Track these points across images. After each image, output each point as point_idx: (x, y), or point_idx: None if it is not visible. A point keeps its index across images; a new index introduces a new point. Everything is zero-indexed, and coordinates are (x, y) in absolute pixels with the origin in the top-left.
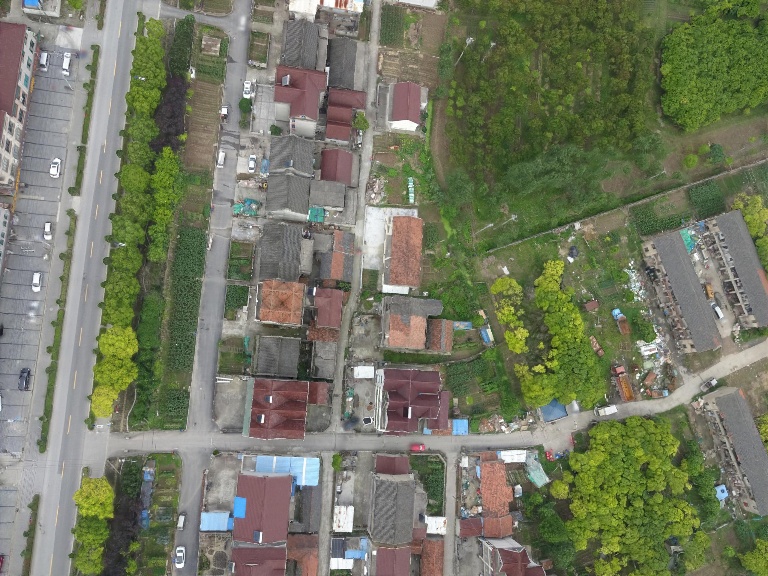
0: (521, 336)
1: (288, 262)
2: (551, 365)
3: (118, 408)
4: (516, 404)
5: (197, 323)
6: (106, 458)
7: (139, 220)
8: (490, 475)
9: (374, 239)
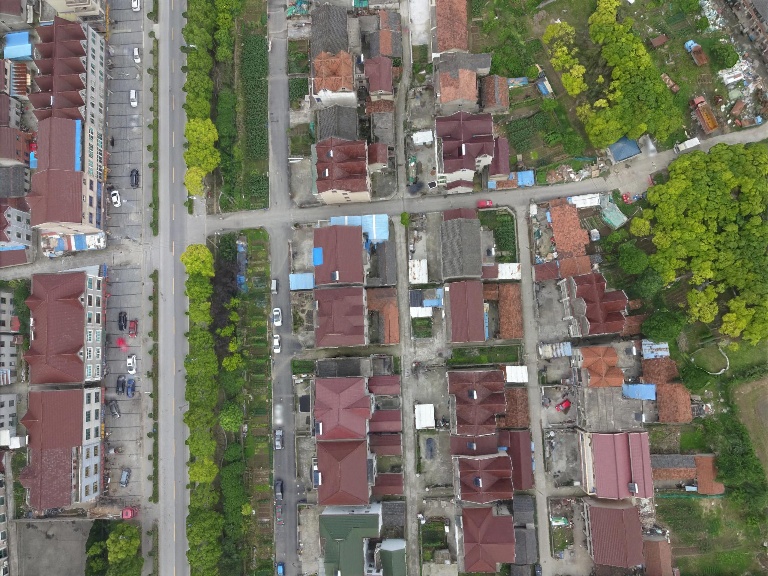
0: (577, 73)
1: (336, 39)
2: (613, 96)
3: (210, 193)
4: (577, 137)
5: (267, 117)
6: (206, 237)
7: (204, 26)
8: (561, 217)
9: (420, 16)
